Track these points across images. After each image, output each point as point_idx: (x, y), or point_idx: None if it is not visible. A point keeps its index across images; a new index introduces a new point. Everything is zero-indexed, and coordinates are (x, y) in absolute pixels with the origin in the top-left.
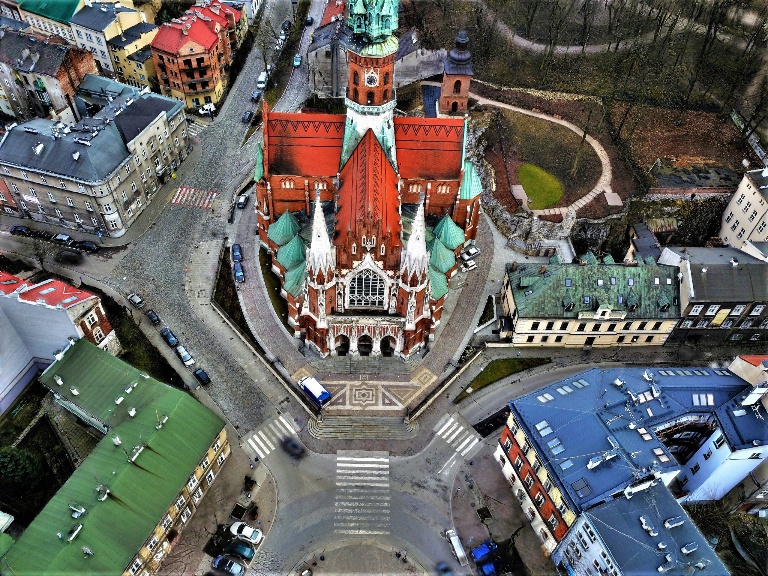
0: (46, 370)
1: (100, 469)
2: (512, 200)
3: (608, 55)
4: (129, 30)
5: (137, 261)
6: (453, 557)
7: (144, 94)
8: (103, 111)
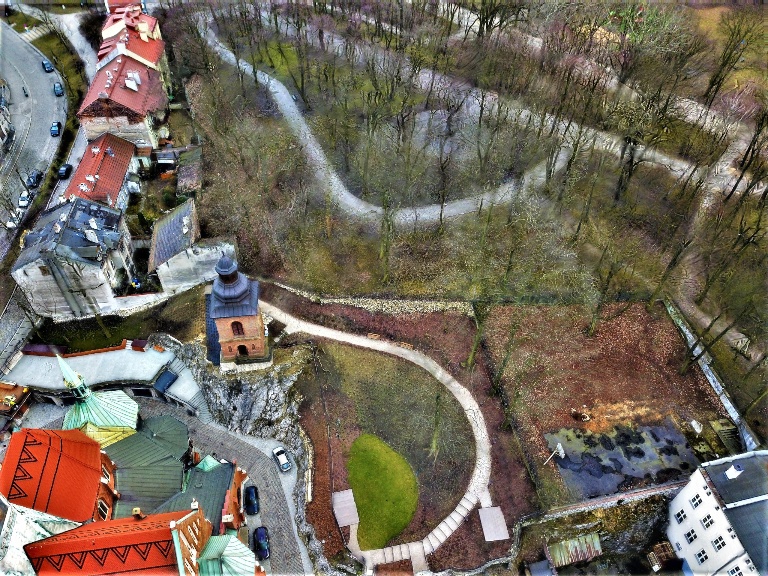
0: None
1: None
2: (334, 528)
3: (481, 219)
4: None
5: None
6: None
7: None
8: None
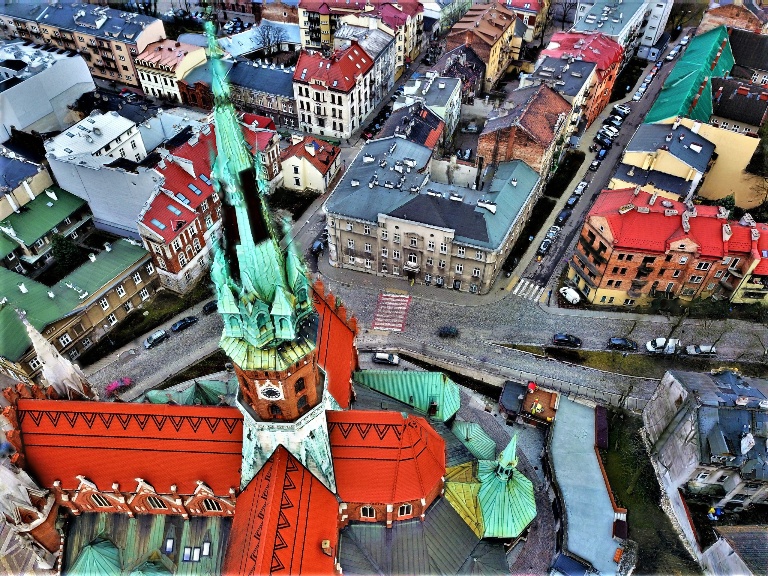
0: (126, 239)
1: (6, 285)
2: None
3: None
4: (660, 174)
5: None
6: None
7: (483, 207)
8: (450, 187)
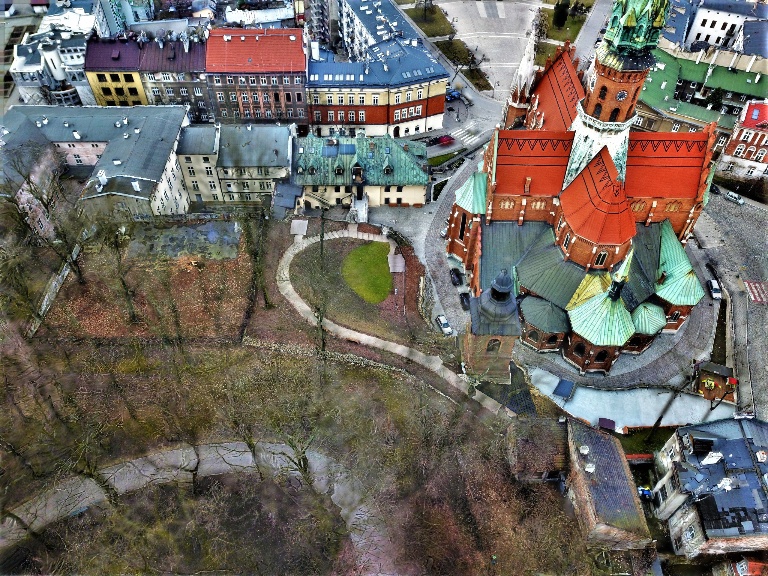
0: None
1: None
2: (406, 256)
3: None
4: None
5: (766, 230)
6: (468, 99)
7: None
8: None
